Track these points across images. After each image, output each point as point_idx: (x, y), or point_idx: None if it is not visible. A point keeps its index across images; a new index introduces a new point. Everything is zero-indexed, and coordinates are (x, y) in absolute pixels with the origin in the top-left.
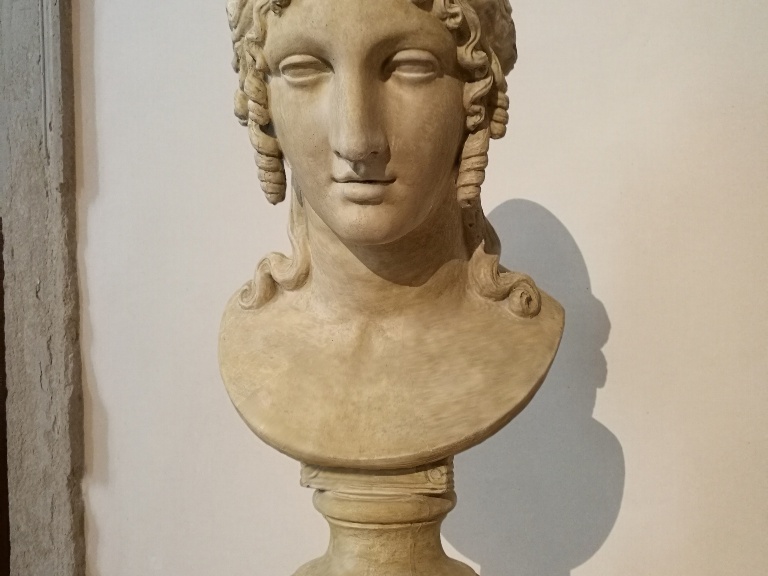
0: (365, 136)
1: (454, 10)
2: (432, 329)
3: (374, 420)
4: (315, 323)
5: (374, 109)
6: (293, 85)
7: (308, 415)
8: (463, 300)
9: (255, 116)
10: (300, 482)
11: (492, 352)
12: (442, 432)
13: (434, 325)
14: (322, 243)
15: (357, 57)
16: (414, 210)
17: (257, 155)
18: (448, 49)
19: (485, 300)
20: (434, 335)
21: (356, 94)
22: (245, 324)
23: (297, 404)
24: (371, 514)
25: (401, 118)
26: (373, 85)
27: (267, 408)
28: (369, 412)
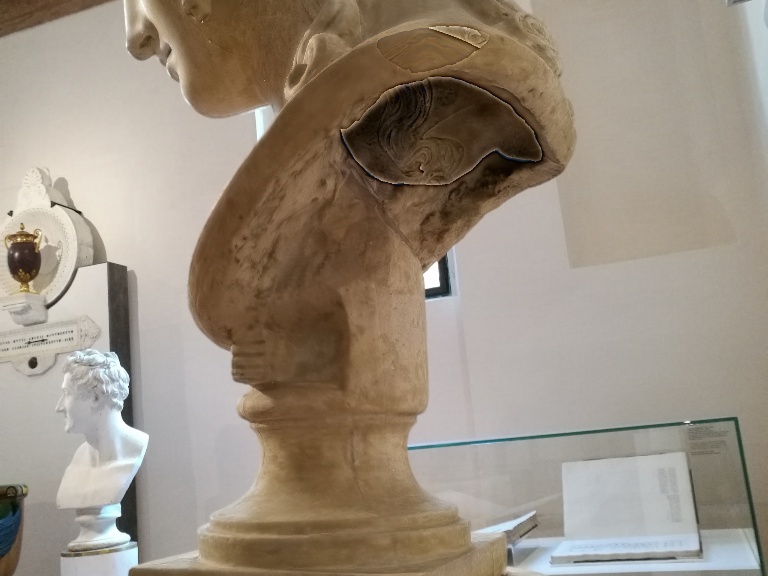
0: (126, 34)
1: None
2: None
3: None
4: None
5: (133, 4)
6: None
7: None
8: None
9: None
10: None
11: None
12: None
13: None
14: None
15: None
16: (188, 61)
17: None
18: None
19: None
20: None
21: None
22: None
23: None
24: None
25: None
26: None
27: None
28: None
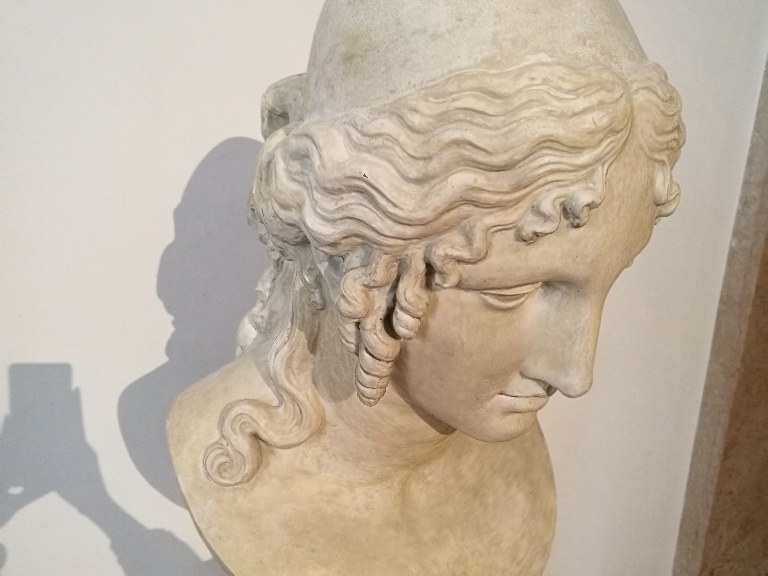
0: None
1: None
2: (462, 456)
3: None
4: (342, 487)
5: None
6: (496, 308)
7: None
8: None
9: (411, 334)
10: None
11: (513, 461)
12: (528, 575)
13: (463, 451)
14: (383, 415)
15: None
16: None
17: (373, 362)
18: None
19: None
20: (465, 462)
21: None
22: (241, 509)
23: None
24: None
25: None
26: None
27: None
28: None
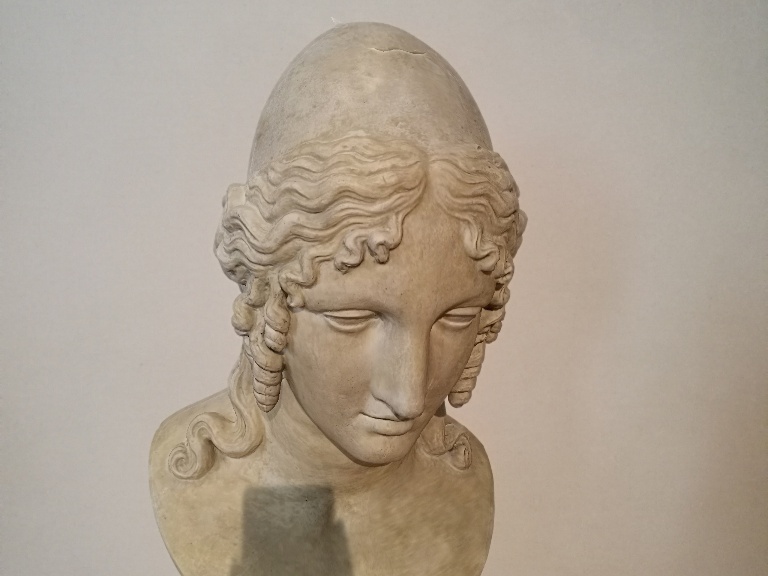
0: (424, 396)
1: (508, 270)
2: (393, 498)
3: None
4: (274, 499)
5: None
6: (337, 330)
7: None
8: (414, 461)
9: (275, 345)
10: None
11: (448, 515)
12: None
13: (395, 493)
14: (299, 433)
15: (427, 324)
16: None
17: (259, 370)
18: (491, 299)
19: (430, 457)
20: (396, 504)
21: (422, 359)
22: (187, 499)
23: None
24: None
25: (442, 362)
26: None
27: None
28: None
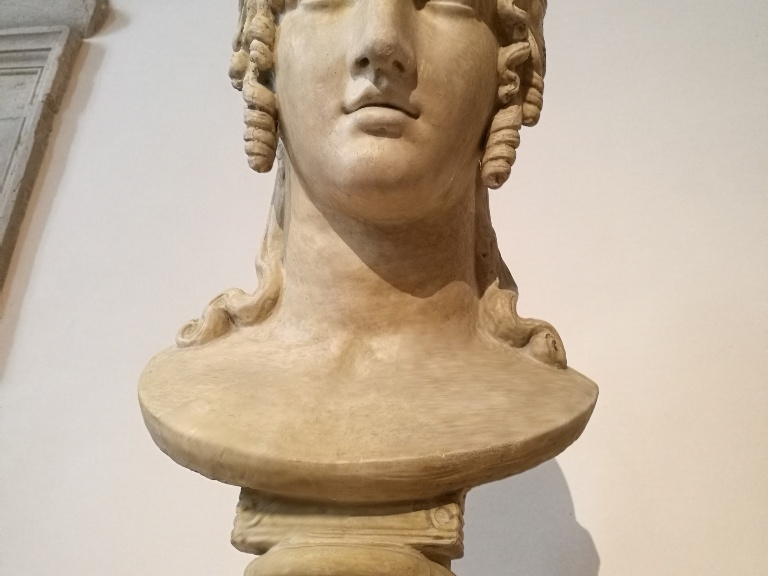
0: (396, 32)
1: None
2: (435, 356)
3: (359, 425)
4: (279, 349)
5: (406, 19)
6: (311, 7)
7: (263, 418)
8: (473, 337)
9: (257, 54)
10: (232, 533)
11: (515, 384)
12: (458, 438)
13: (438, 352)
14: (306, 237)
15: None
16: (435, 163)
17: (248, 111)
18: None
19: (500, 343)
20: (438, 362)
21: None
22: (182, 357)
23: (248, 409)
24: (343, 559)
25: (434, 43)
26: None
27: (203, 413)
28: (352, 418)
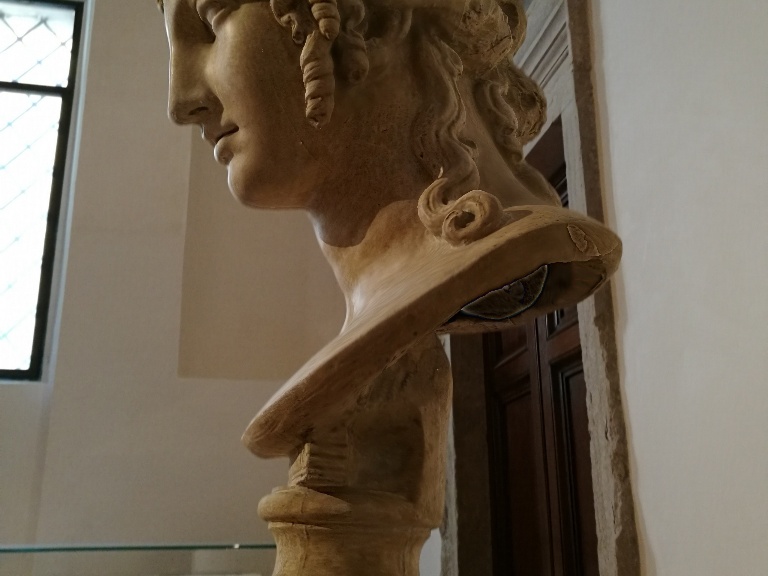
0: (175, 96)
1: None
2: (378, 291)
3: None
4: None
5: (191, 70)
6: None
7: None
8: (418, 249)
9: None
10: None
11: (393, 296)
12: None
13: (380, 286)
14: None
15: (170, 34)
16: (266, 151)
17: None
18: None
19: (439, 241)
20: (375, 297)
21: None
22: None
23: None
24: (259, 506)
25: (215, 66)
26: (193, 50)
27: None
28: None
